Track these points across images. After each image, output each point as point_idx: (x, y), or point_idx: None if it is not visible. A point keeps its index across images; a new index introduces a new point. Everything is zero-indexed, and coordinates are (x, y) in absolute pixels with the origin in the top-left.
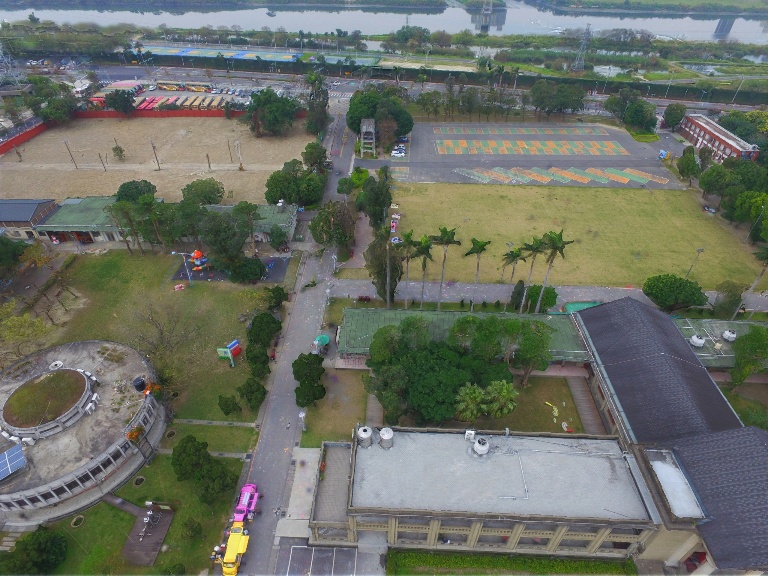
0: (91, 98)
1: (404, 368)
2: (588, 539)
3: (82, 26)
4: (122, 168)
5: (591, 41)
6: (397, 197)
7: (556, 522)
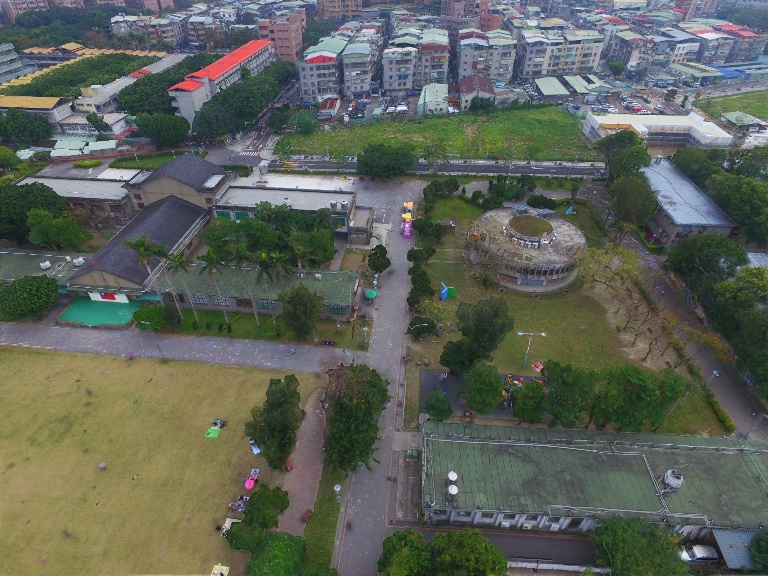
0: None
1: None
2: None
3: None
4: None
5: None
6: None
7: None
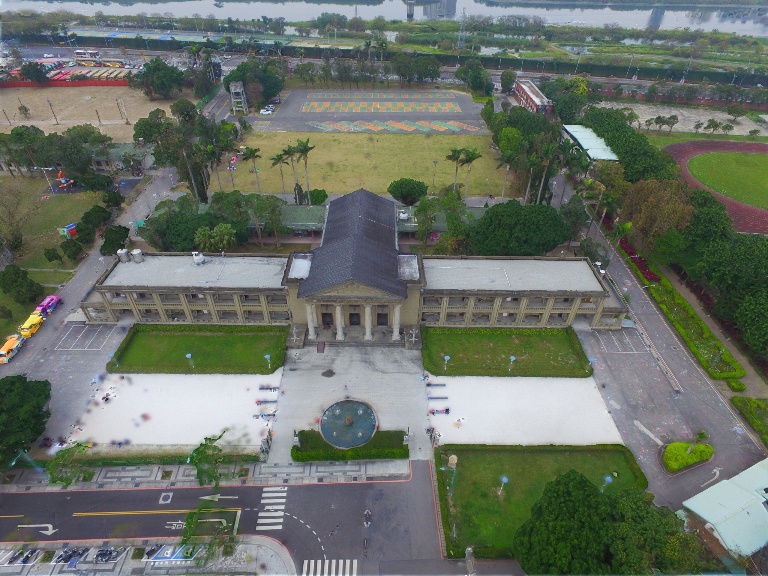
0: (12, 71)
1: None
2: (258, 309)
3: (1, 7)
4: (26, 123)
5: (468, 23)
6: (249, 141)
7: (227, 291)
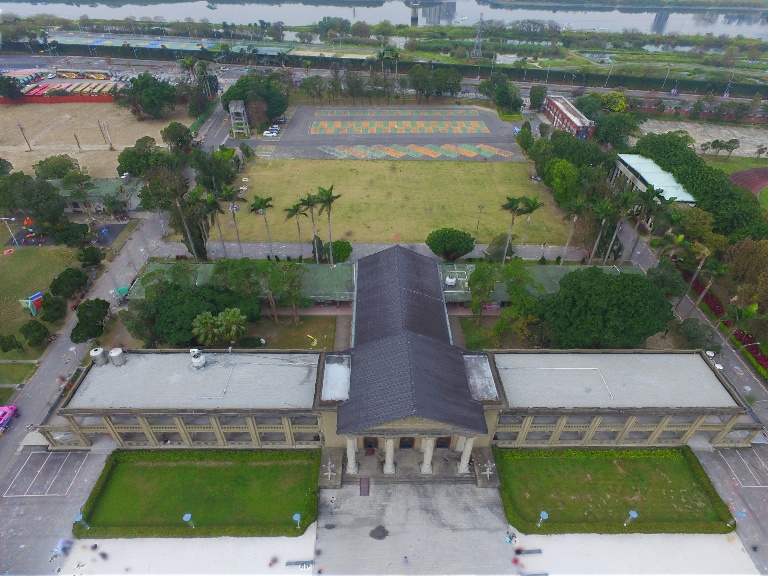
0: None
1: (157, 303)
2: (279, 431)
3: None
4: None
5: (485, 30)
6: (252, 172)
7: (238, 414)
